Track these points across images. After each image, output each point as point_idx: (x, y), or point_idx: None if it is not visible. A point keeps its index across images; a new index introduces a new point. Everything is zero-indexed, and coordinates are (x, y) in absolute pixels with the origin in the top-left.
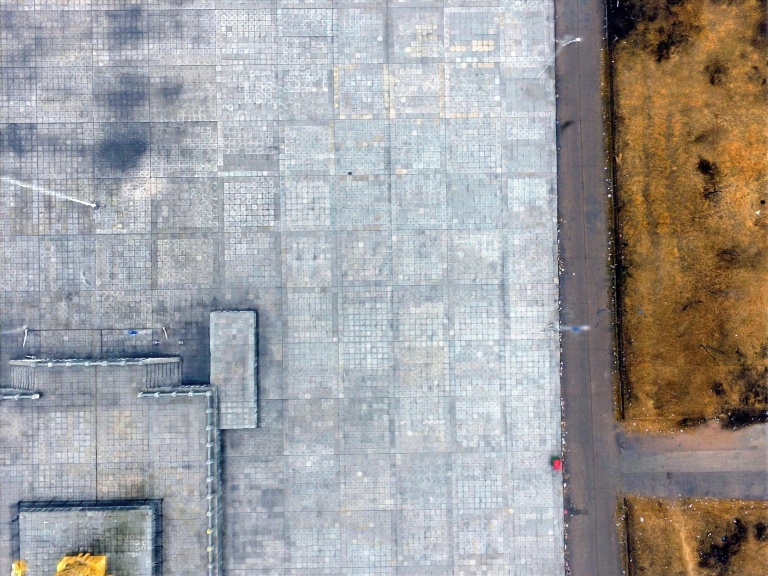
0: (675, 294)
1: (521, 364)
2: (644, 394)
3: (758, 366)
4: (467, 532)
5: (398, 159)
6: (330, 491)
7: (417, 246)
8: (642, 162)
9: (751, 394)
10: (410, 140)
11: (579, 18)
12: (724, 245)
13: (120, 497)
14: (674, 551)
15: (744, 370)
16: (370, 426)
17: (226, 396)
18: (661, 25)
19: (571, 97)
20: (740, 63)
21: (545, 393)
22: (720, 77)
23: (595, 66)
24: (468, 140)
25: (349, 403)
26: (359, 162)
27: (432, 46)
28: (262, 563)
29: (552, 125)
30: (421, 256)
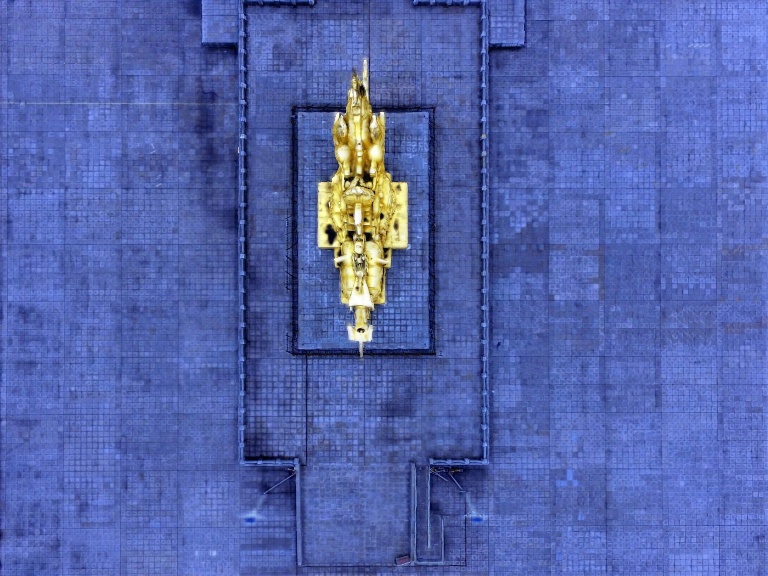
0: None
1: None
2: None
3: None
4: (731, 155)
5: None
6: (595, 112)
7: None
8: None
9: None
10: None
11: None
12: None
13: (393, 105)
14: None
15: None
16: (635, 48)
17: (496, 10)
18: None
19: None
20: None
21: None
22: None
23: None
24: None
25: (615, 25)
26: None
27: None
28: (526, 182)
29: None
30: None
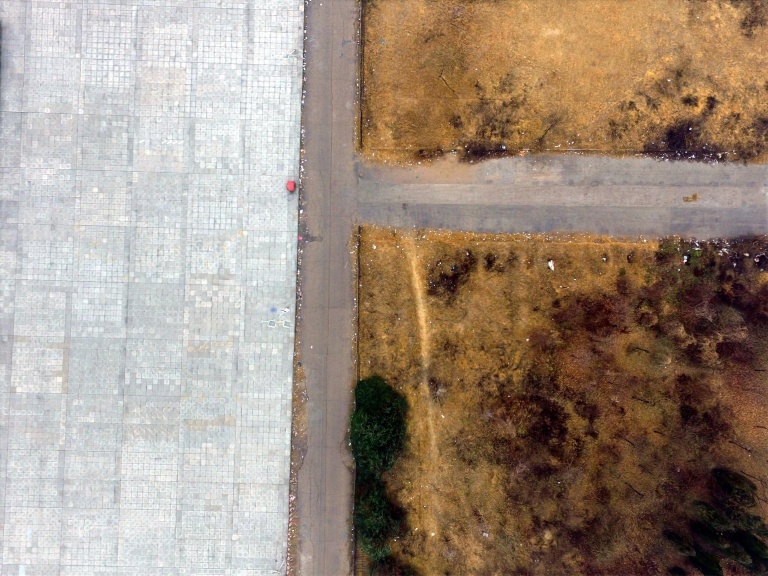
0: (418, 26)
1: (263, 89)
2: (383, 124)
3: (496, 100)
4: (200, 252)
5: None
6: (65, 205)
7: None
8: None
9: (488, 127)
10: None
11: None
12: None
13: None
14: (404, 278)
15: (482, 104)
16: (108, 143)
17: None
18: None
19: None
20: None
21: (285, 119)
22: None
23: None
24: None
25: (89, 119)
26: None
27: None
28: None
29: None
30: None
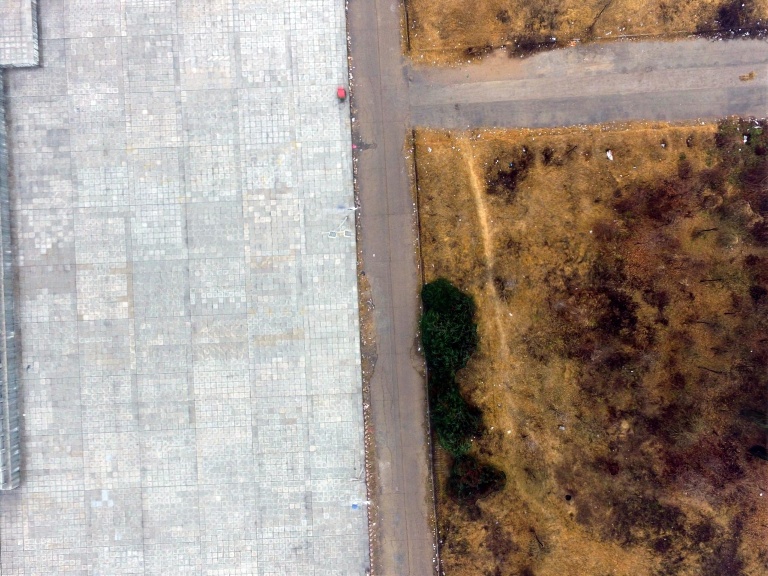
0: None
1: None
2: (430, 24)
3: None
4: (255, 167)
5: None
6: (116, 130)
7: None
8: None
9: (536, 20)
10: None
11: None
12: None
13: None
14: (462, 179)
15: None
16: (154, 64)
17: (4, 31)
18: None
19: None
20: None
21: (330, 26)
22: None
23: None
24: None
25: (132, 41)
26: None
27: None
28: (50, 203)
29: None
30: None
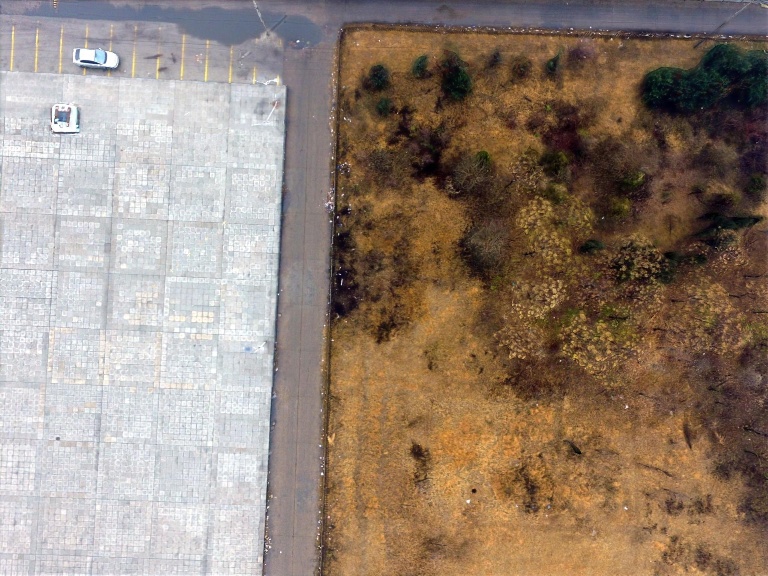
0: None
1: None
2: None
3: None
4: None
5: (108, 427)
6: None
7: (121, 516)
8: (355, 444)
9: None
10: (122, 408)
11: (304, 293)
12: (431, 534)
13: None
14: None
15: None
16: None
17: None
18: (383, 306)
19: (290, 372)
20: (458, 350)
21: None
22: (436, 364)
23: (317, 342)
24: (181, 411)
25: None
26: (68, 427)
27: (151, 314)
28: None
29: (267, 401)
30: (124, 527)
